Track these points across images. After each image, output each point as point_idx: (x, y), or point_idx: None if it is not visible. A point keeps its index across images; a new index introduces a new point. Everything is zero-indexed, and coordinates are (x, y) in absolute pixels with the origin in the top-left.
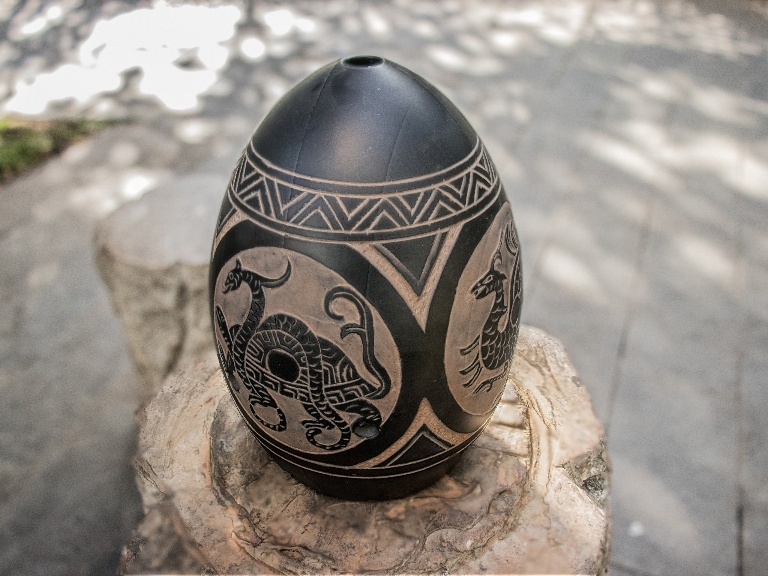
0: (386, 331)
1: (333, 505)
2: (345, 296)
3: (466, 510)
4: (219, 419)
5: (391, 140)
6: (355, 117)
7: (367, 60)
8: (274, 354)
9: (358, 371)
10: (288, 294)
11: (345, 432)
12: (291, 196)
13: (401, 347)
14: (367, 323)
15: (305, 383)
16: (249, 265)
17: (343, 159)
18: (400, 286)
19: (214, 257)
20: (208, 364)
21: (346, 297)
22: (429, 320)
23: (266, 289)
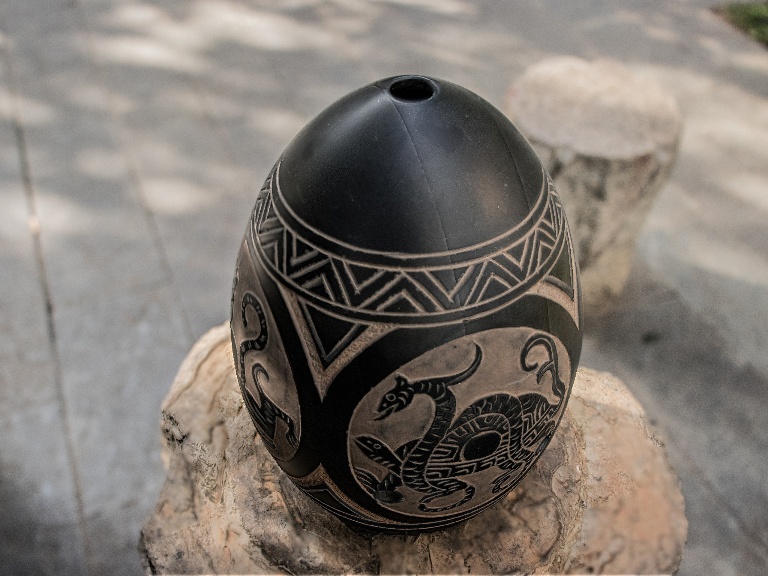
0: (564, 350)
1: (465, 528)
2: (536, 343)
3: (550, 446)
4: (270, 543)
5: (513, 166)
6: (474, 159)
7: (403, 85)
8: (473, 442)
9: (548, 401)
10: (483, 377)
11: (529, 461)
12: (456, 278)
13: (571, 355)
14: (554, 354)
15: (505, 446)
16: (421, 374)
17: (492, 210)
18: (563, 303)
19: (331, 390)
20: (175, 501)
21: (537, 344)
22: (579, 317)
23: (454, 387)
